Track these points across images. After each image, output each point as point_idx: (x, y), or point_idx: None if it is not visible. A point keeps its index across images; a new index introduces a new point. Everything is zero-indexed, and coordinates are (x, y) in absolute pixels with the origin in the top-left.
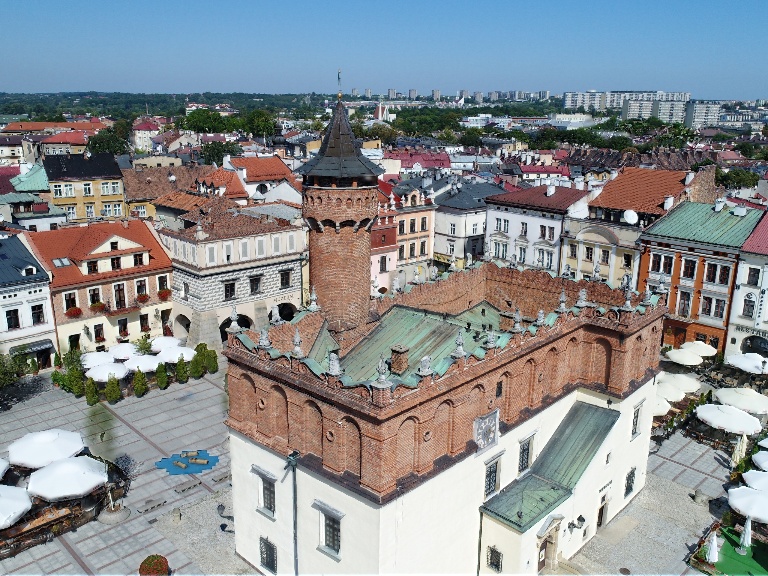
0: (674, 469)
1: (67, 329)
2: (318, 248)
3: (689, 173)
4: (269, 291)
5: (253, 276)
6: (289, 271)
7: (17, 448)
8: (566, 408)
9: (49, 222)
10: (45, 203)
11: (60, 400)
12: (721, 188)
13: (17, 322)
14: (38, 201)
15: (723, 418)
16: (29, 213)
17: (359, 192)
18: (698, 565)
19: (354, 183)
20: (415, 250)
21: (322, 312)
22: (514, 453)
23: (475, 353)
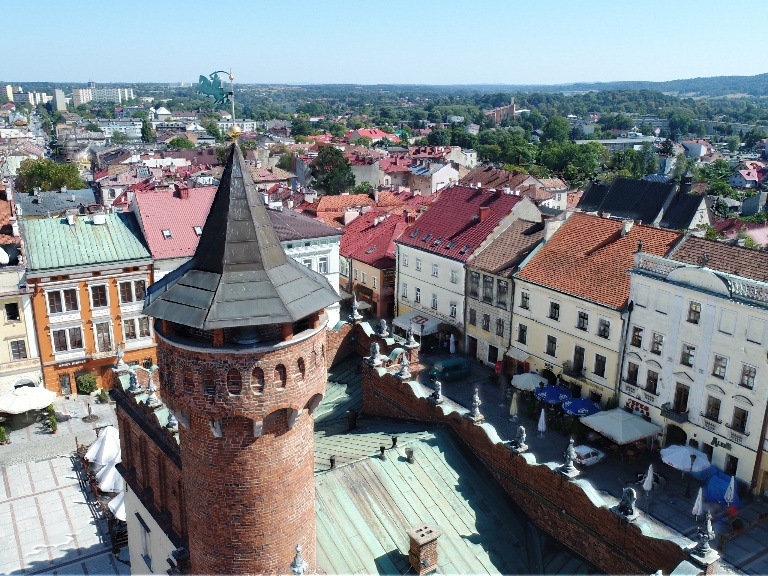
0: None
1: None
2: (281, 466)
3: (9, 186)
4: None
5: None
6: None
7: None
8: None
9: None
10: None
11: None
12: None
13: None
14: None
15: None
16: None
17: None
18: None
19: None
20: None
21: None
22: None
23: (529, 463)
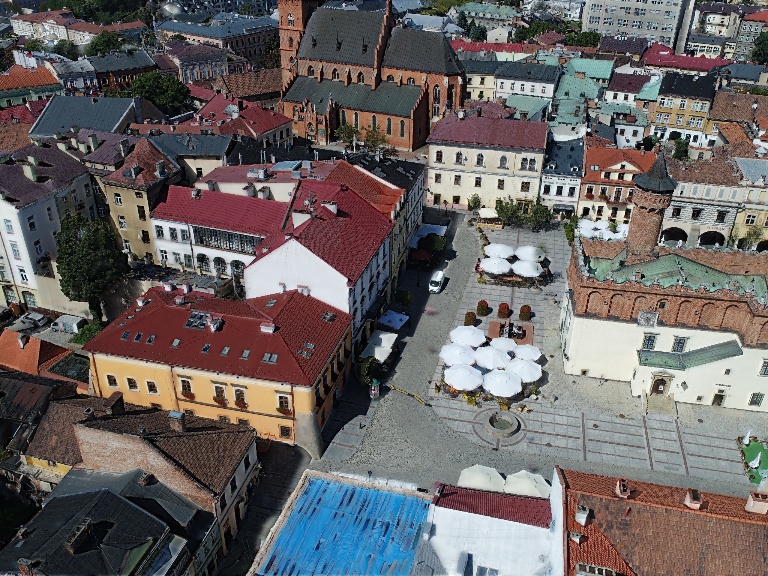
0: None
1: (584, 203)
2: None
3: None
4: (706, 220)
5: (696, 208)
6: (726, 212)
7: (520, 249)
8: (724, 339)
9: (634, 129)
10: (635, 116)
11: (560, 237)
12: None
13: (561, 192)
14: (634, 113)
15: None
16: (624, 121)
17: (652, 196)
18: None
19: (650, 191)
20: None
21: (627, 242)
22: (669, 339)
23: None
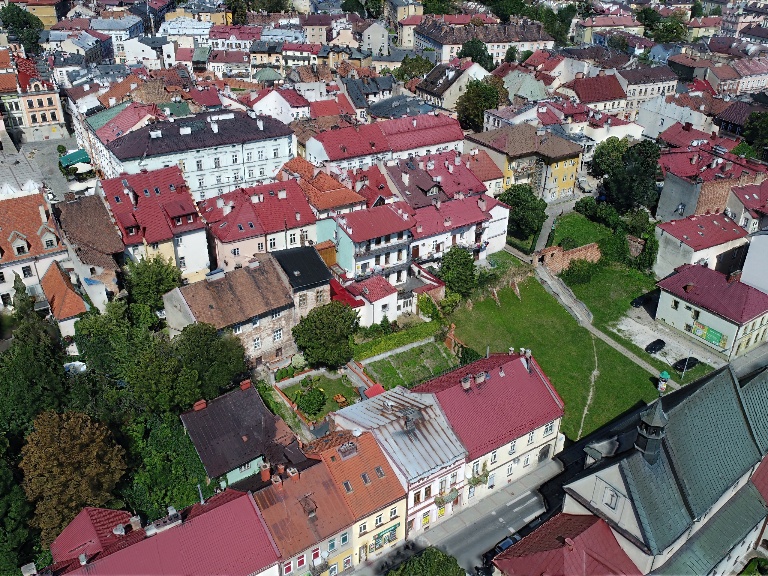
0: None
1: None
2: None
3: (130, 84)
4: None
5: None
6: None
7: None
8: None
9: None
10: None
11: None
12: (176, 91)
13: None
14: None
15: None
16: None
17: None
18: None
19: None
20: (47, 117)
21: None
22: None
23: None
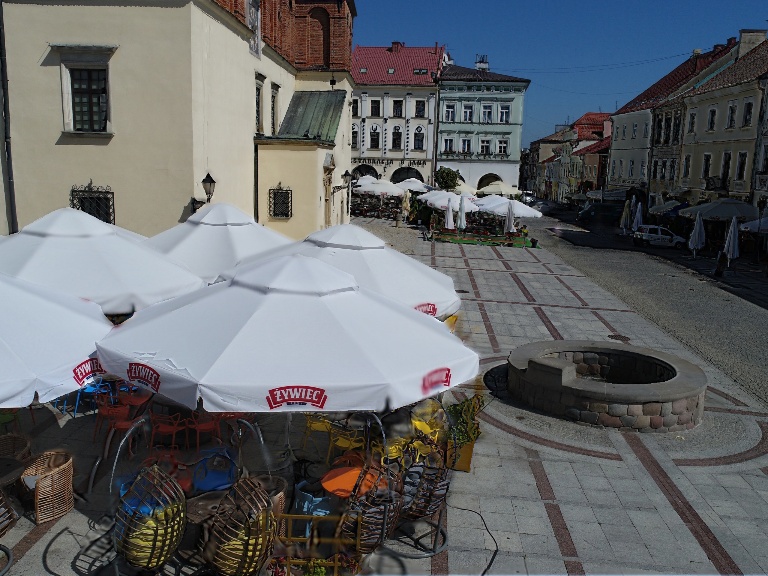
0: (361, 222)
1: None
2: None
3: None
4: None
5: None
6: None
7: None
8: (290, 91)
9: None
10: None
11: None
12: None
13: None
14: None
15: (381, 187)
16: None
17: None
18: (441, 236)
19: None
20: None
21: None
22: (269, 96)
23: None
